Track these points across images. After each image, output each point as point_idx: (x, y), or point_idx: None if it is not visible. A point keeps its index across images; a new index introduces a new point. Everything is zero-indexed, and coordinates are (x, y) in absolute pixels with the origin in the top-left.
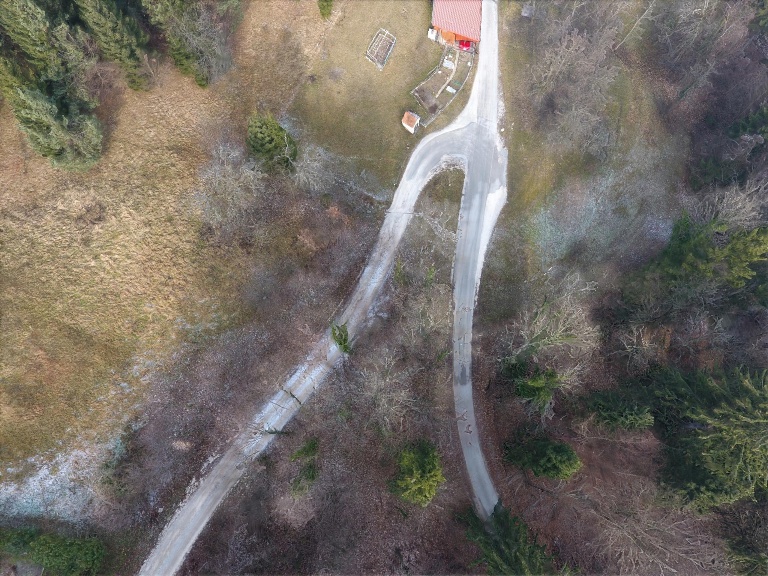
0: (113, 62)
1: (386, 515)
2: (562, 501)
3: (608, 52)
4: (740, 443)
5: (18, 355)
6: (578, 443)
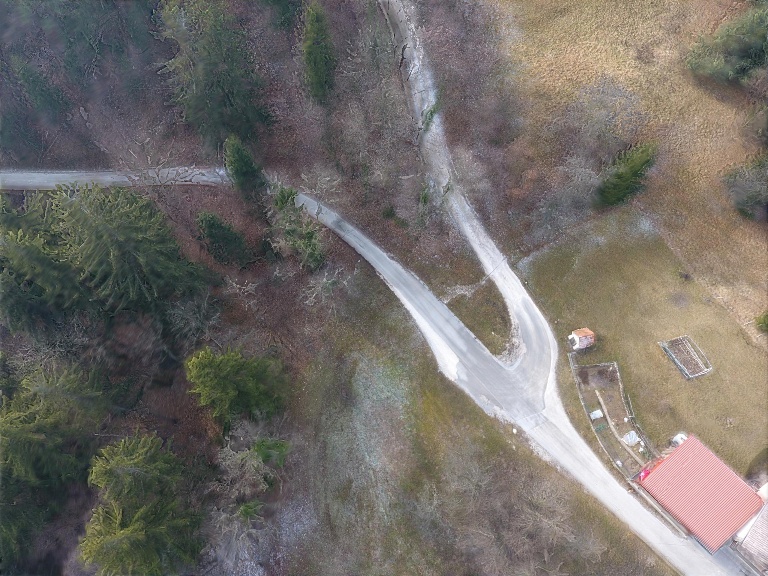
0: (765, 86)
1: None
2: None
3: None
4: None
5: None
6: None
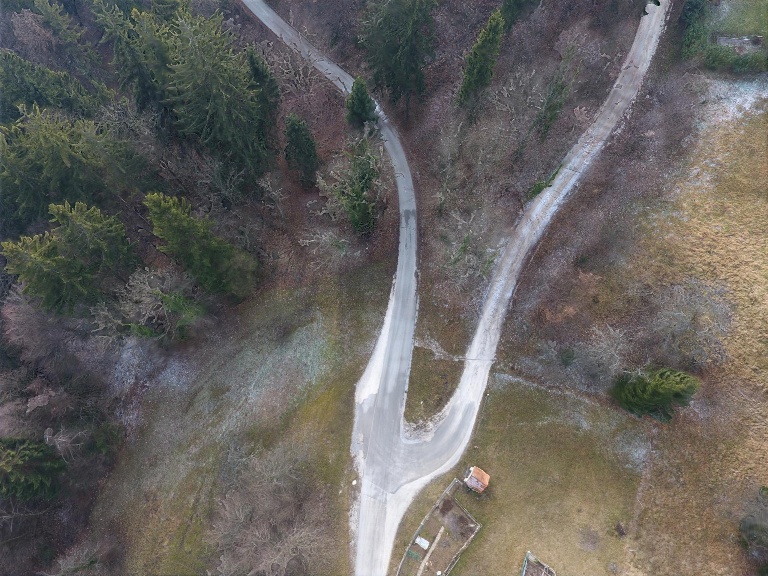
0: None
1: None
2: None
3: None
4: None
5: None
6: None
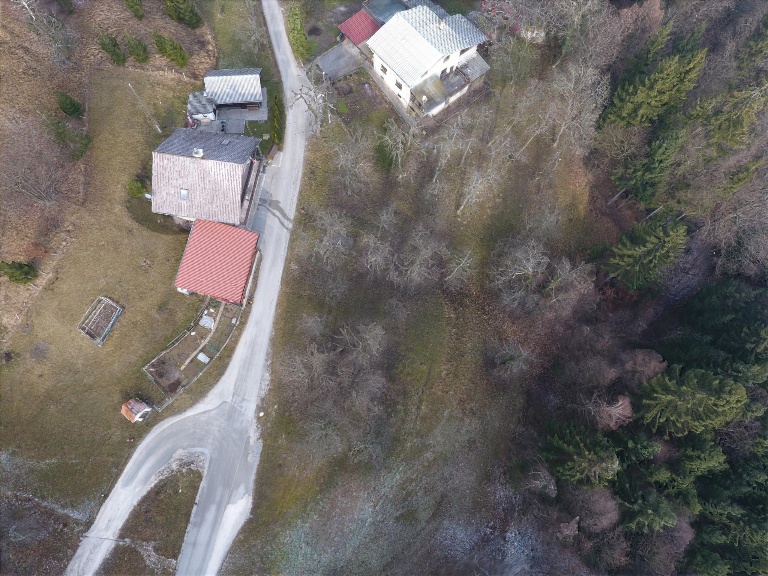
0: None
1: None
2: None
3: (432, 288)
4: None
5: None
6: None
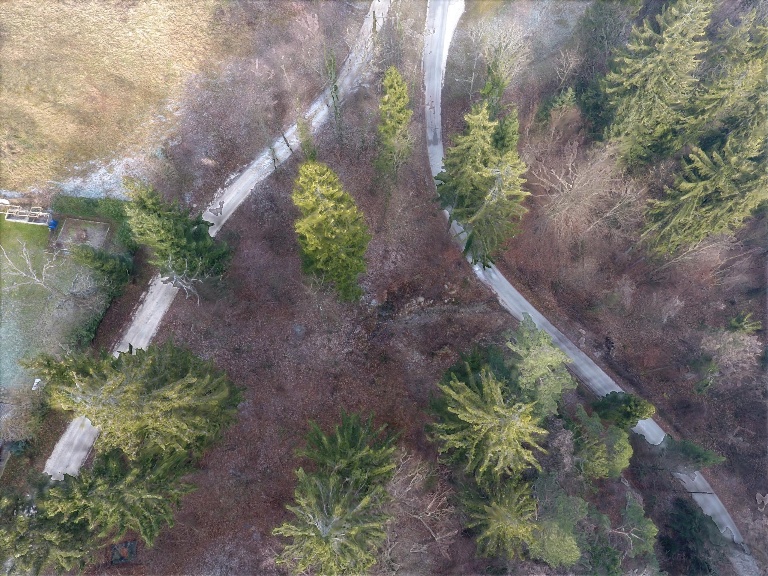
0: None
1: (376, 229)
2: (523, 236)
3: None
4: (634, 80)
5: (77, 90)
6: (525, 151)
